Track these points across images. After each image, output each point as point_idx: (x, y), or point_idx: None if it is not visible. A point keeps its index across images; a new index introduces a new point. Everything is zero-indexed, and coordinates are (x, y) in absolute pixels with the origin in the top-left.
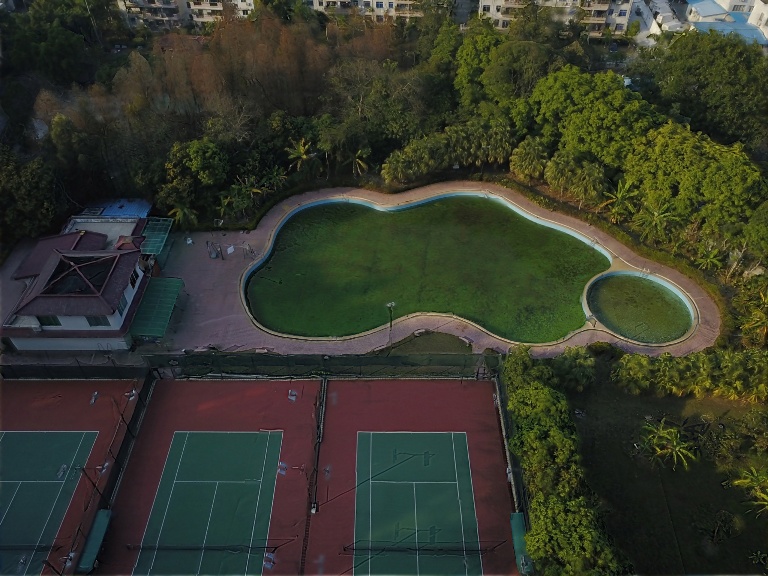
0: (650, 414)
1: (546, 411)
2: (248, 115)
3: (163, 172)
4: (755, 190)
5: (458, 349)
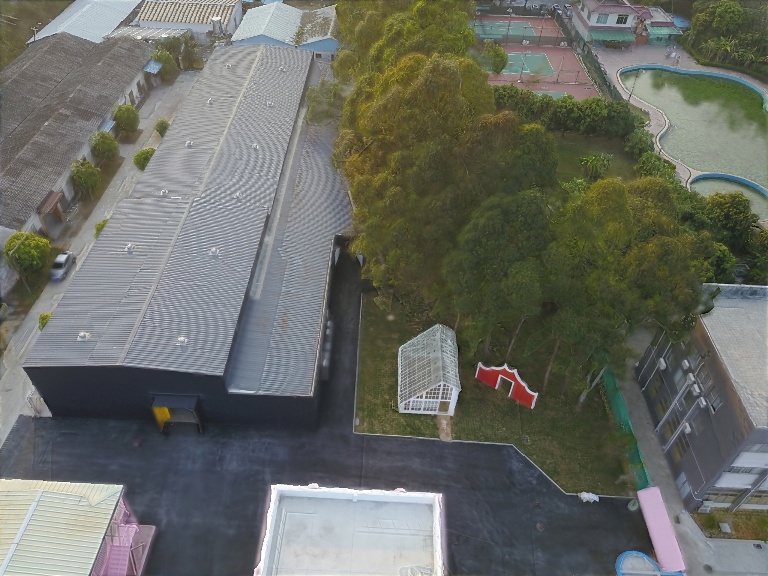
0: (623, 179)
1: (588, 102)
2: None
3: (706, 8)
4: None
5: None
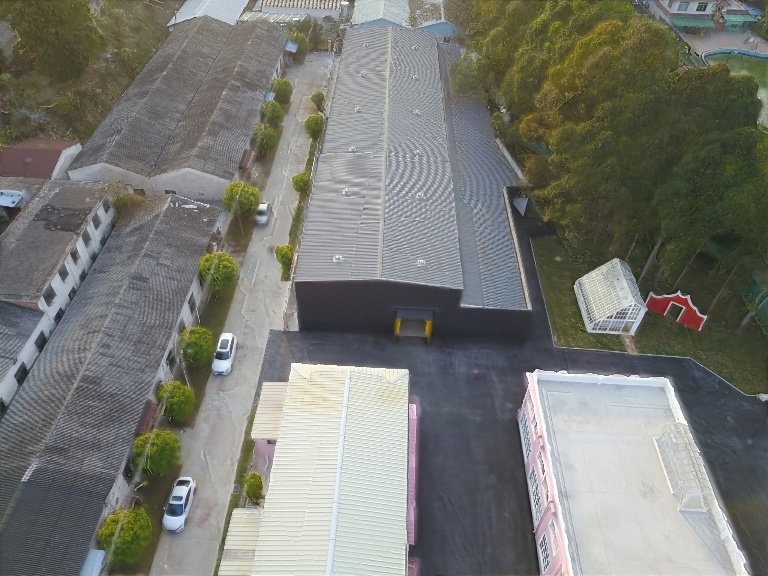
0: None
1: None
2: None
3: None
4: None
5: None
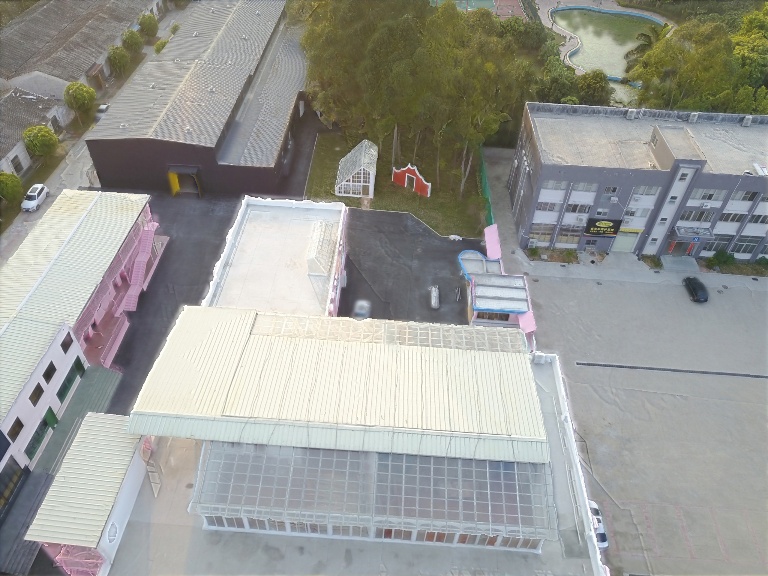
0: None
1: (509, 21)
2: None
3: None
4: None
5: (557, 43)
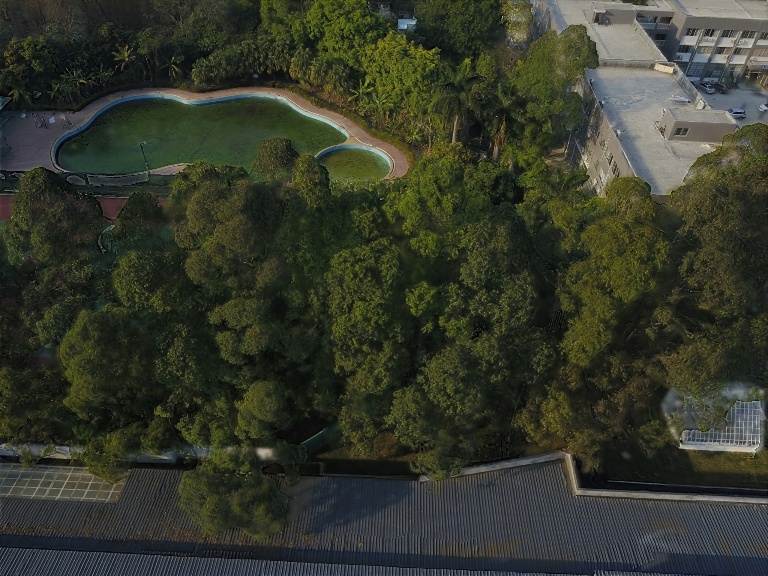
0: None
1: None
2: (77, 21)
3: (2, 60)
4: (434, 78)
5: None
